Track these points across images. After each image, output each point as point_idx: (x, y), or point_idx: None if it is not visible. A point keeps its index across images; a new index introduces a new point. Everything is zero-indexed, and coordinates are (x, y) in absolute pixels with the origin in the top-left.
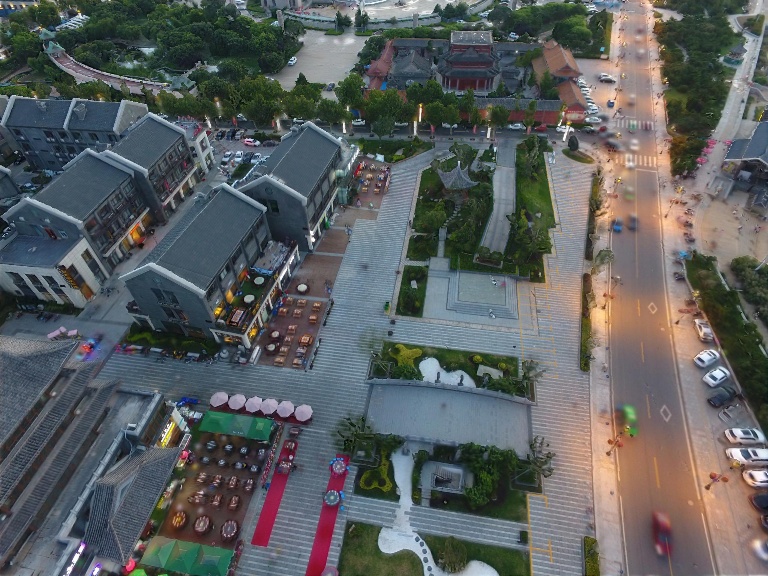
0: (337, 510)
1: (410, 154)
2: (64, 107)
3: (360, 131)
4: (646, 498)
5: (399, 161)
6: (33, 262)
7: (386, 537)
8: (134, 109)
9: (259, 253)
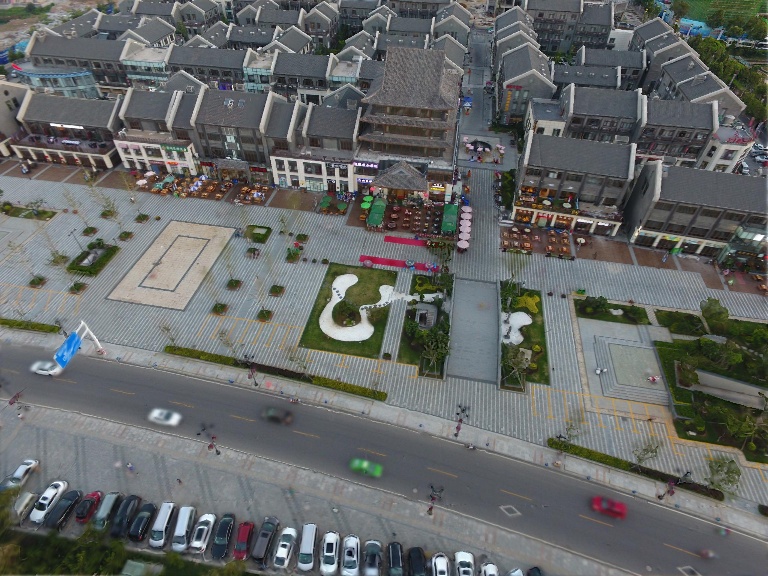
0: None
1: None
2: (698, 73)
3: None
4: (418, 452)
5: None
6: (538, 114)
7: (388, 288)
8: (729, 100)
9: (597, 201)
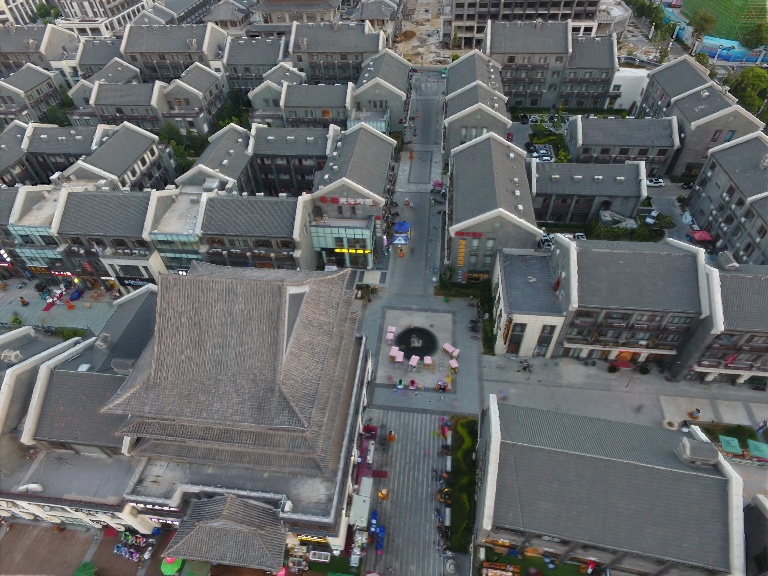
0: None
1: None
2: None
3: None
4: None
5: None
6: (514, 289)
7: None
8: None
9: (651, 575)
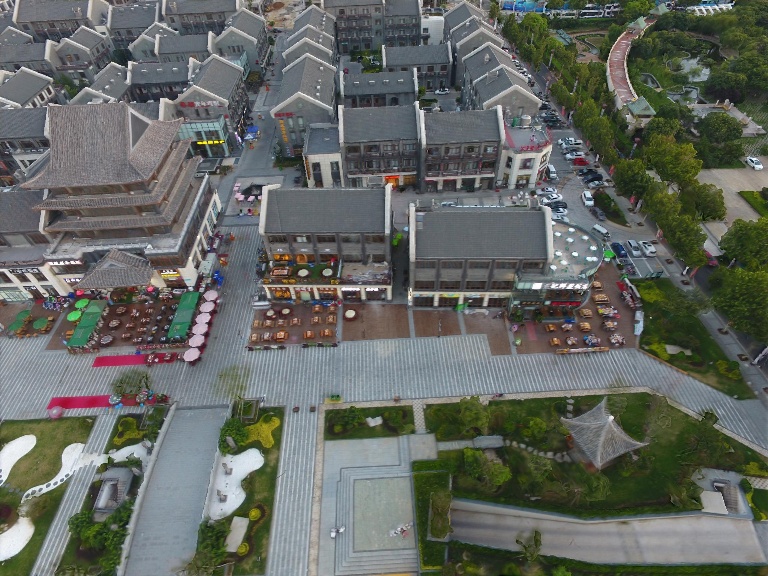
0: (108, 406)
1: (685, 366)
2: (493, 68)
3: (705, 290)
4: None
5: (651, 354)
6: (314, 145)
7: (76, 449)
8: (522, 98)
9: (363, 259)
